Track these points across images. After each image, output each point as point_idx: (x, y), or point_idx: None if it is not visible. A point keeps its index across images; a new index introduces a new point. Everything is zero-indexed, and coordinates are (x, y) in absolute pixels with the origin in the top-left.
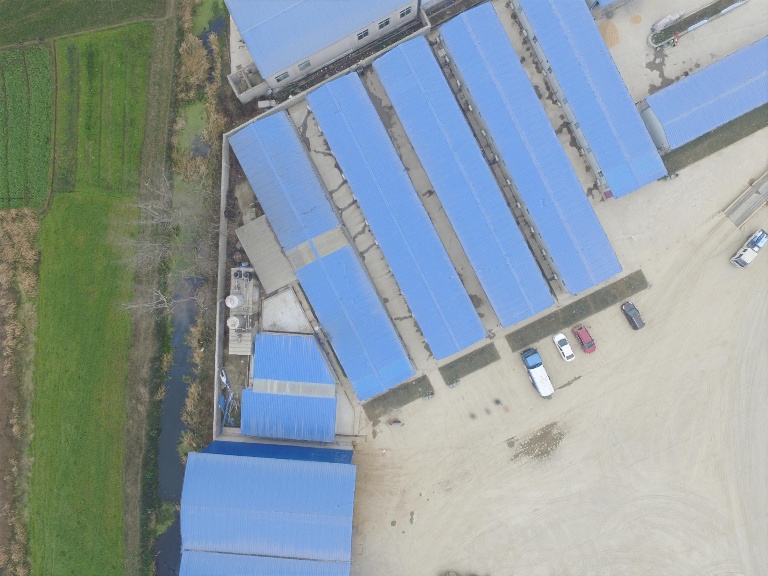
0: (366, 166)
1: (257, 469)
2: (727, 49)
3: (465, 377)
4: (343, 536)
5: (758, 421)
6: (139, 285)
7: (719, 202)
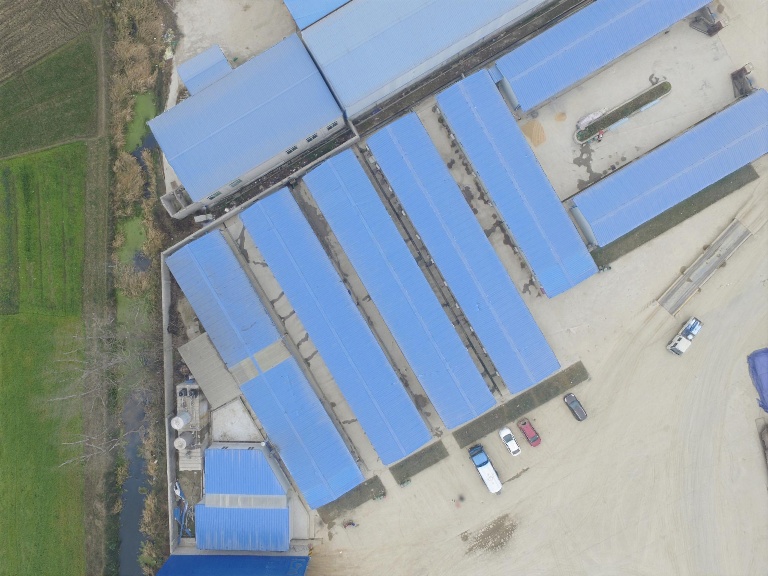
0: (302, 281)
1: None
2: (651, 141)
3: (416, 475)
4: None
5: (703, 501)
6: (89, 402)
7: (653, 291)
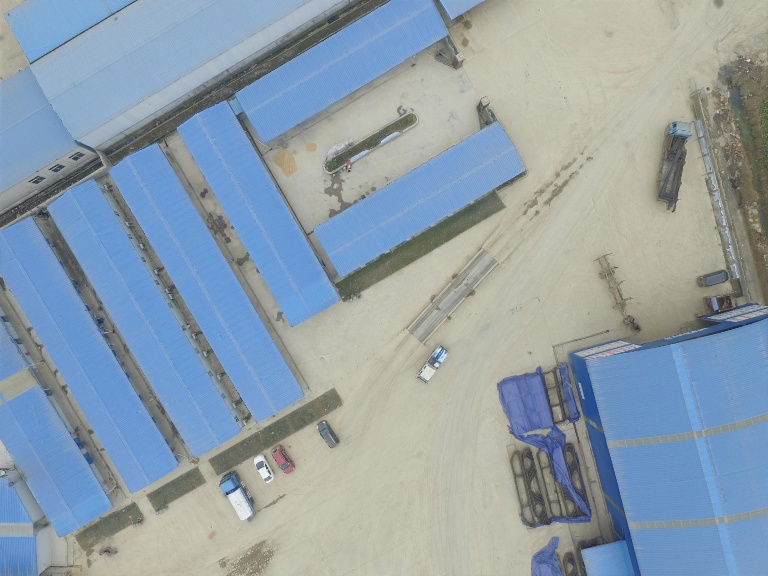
0: (44, 310)
1: None
2: (401, 172)
3: (173, 502)
4: None
5: (457, 527)
6: None
7: (404, 319)
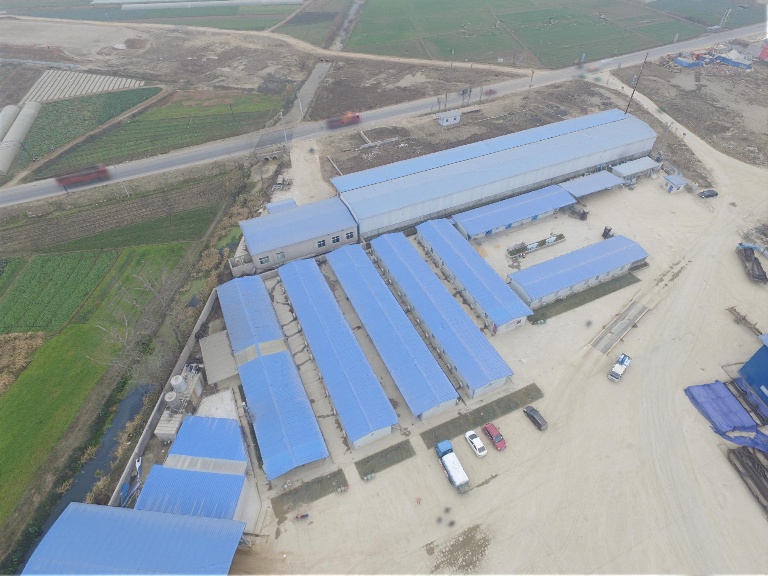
0: (310, 302)
1: (136, 521)
2: None
3: (381, 472)
4: None
5: (699, 529)
6: (99, 386)
7: (584, 339)
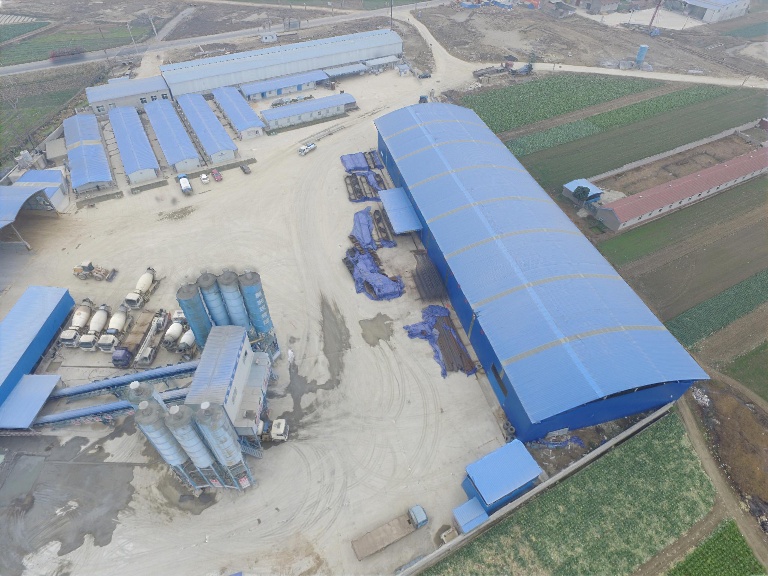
0: (123, 123)
1: None
2: None
3: (145, 191)
4: (17, 205)
5: (311, 202)
6: None
7: (296, 140)
